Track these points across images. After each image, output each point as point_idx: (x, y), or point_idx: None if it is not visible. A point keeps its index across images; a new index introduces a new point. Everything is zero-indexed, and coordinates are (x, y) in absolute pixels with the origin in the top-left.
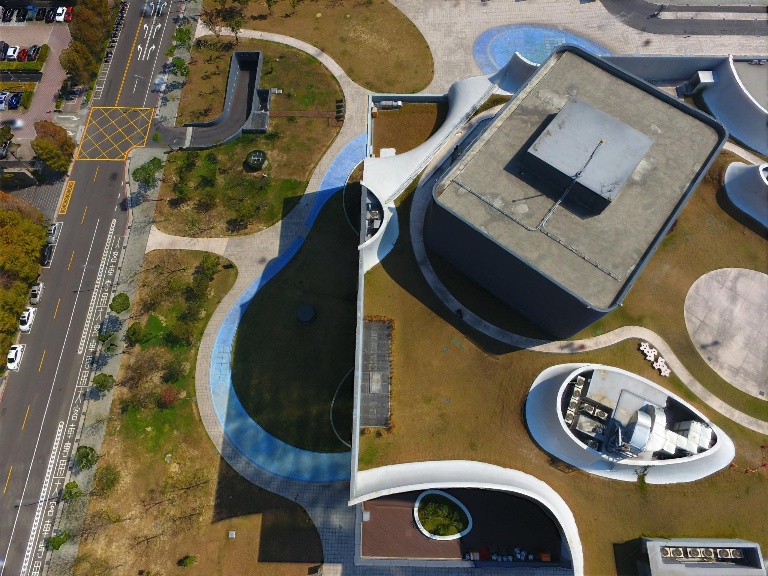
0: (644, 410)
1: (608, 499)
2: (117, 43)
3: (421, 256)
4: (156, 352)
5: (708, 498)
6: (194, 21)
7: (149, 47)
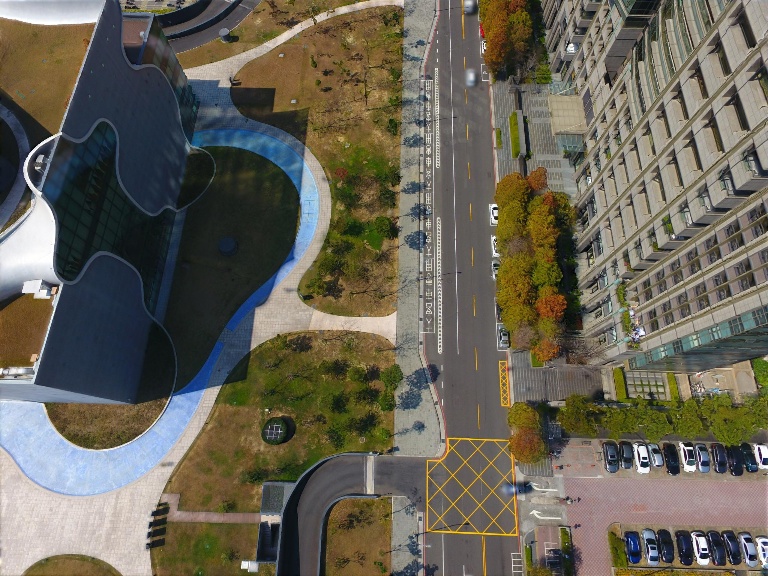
0: None
1: None
2: None
3: None
4: (369, 218)
5: None
6: None
7: None
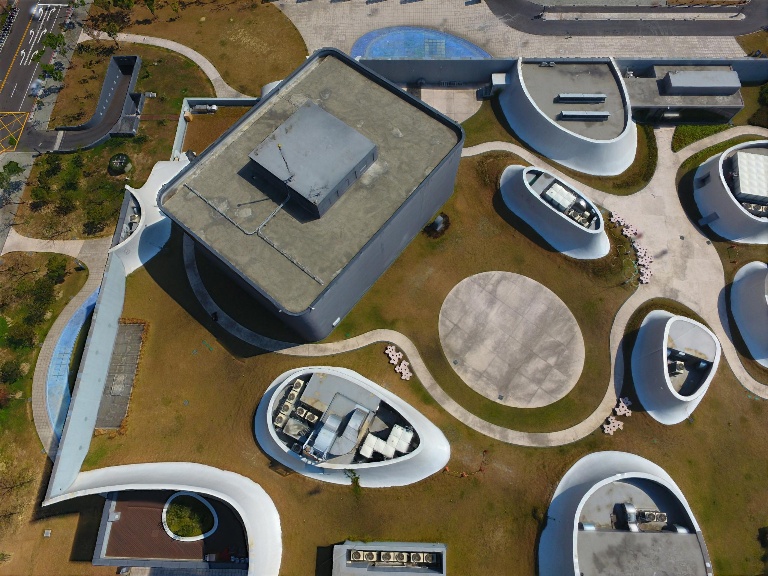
0: None
1: (321, 502)
2: (2, 48)
3: (189, 259)
4: None
5: (421, 502)
6: (79, 26)
7: (32, 52)
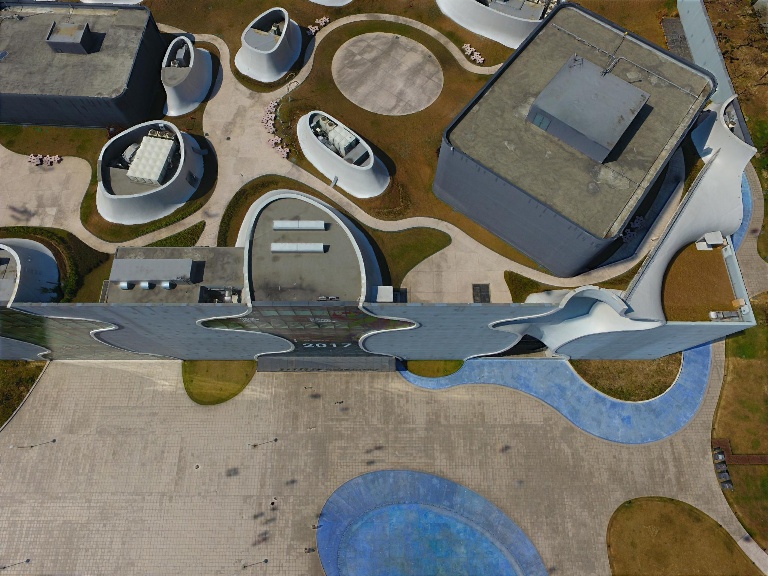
0: None
1: None
2: None
3: None
4: None
5: None
6: None
7: None
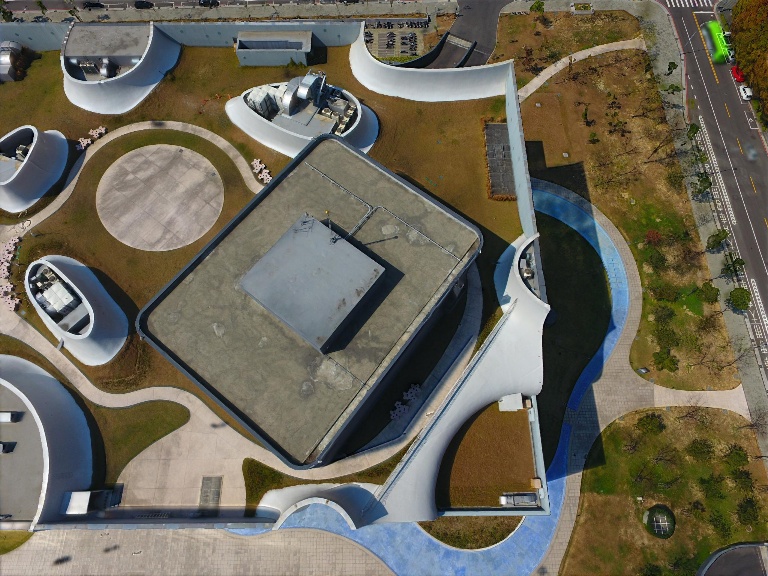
0: (293, 113)
1: None
2: None
3: None
4: (681, 281)
5: (253, 86)
6: None
7: None
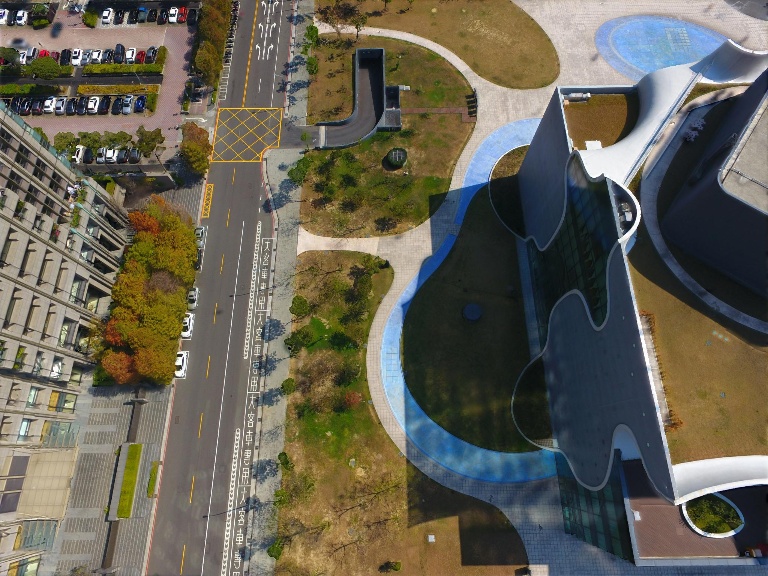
0: None
1: None
2: (234, 43)
3: (662, 249)
4: (323, 355)
5: None
6: (309, 19)
7: (267, 46)
